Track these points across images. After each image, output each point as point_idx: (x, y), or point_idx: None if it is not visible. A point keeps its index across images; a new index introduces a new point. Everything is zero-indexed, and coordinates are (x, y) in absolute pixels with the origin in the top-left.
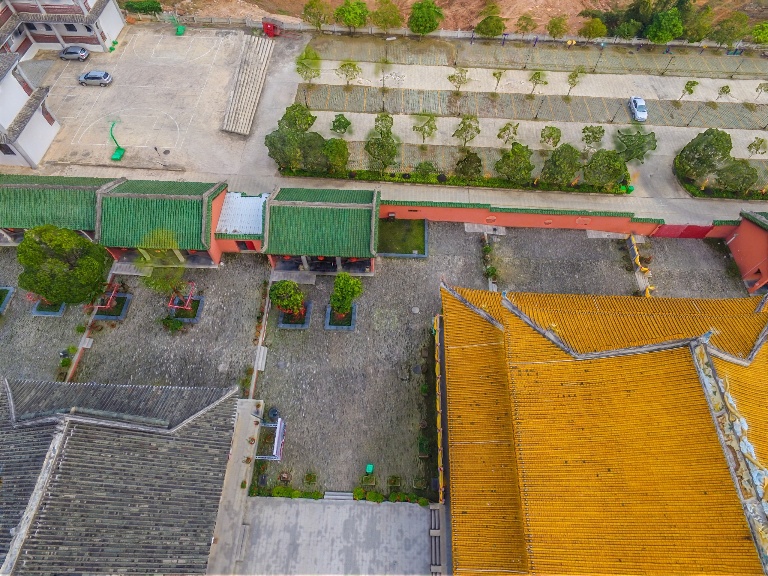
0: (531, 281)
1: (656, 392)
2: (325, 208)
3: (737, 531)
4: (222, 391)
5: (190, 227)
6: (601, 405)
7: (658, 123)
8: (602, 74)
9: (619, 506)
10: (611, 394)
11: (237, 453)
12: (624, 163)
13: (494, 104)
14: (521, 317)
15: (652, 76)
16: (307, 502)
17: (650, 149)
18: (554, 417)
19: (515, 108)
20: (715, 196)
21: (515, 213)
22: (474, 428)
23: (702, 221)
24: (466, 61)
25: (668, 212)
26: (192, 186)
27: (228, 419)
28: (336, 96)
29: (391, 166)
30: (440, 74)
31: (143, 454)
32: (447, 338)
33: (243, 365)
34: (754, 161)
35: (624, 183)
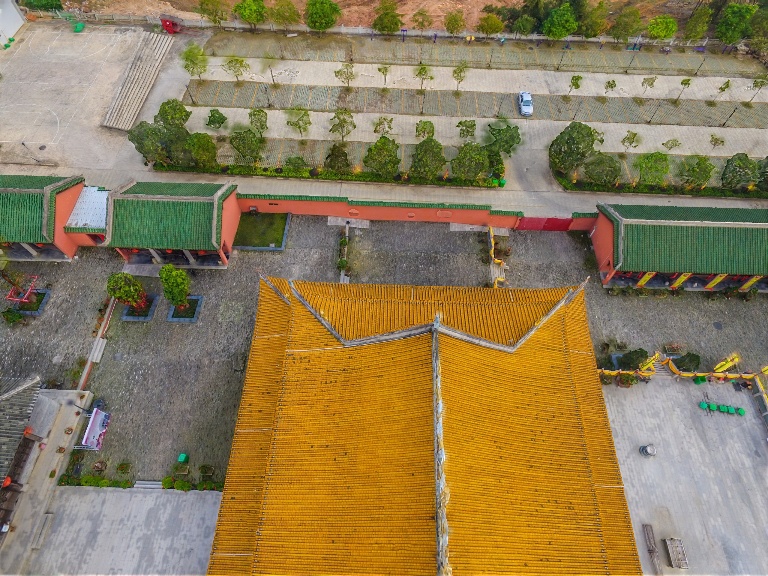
0: (385, 273)
1: (399, 377)
2: (169, 201)
3: (427, 511)
4: (24, 381)
5: (33, 220)
6: (354, 391)
7: (544, 118)
8: (497, 69)
9: (345, 489)
10: (364, 380)
11: (52, 443)
12: (500, 157)
13: (383, 99)
14: (306, 306)
15: (547, 71)
16: (115, 491)
17: (514, 142)
18: (313, 403)
19: (403, 103)
20: (586, 189)
21: (374, 206)
22: (260, 416)
23: (570, 214)
24: (363, 57)
25: (538, 205)
26: (46, 180)
27: (25, 408)
28: (226, 92)
29: (267, 161)
30: (335, 70)
31: None
32: (257, 328)
33: (78, 357)
34: (633, 155)
35: (497, 177)
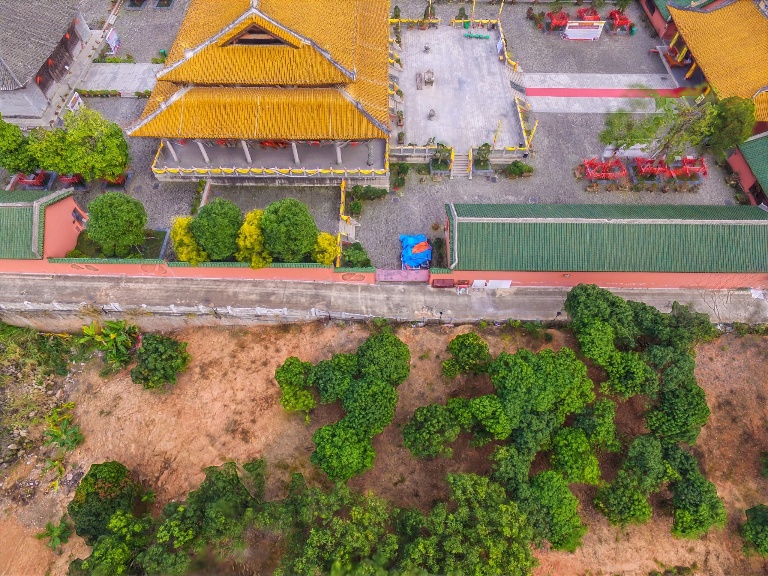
0: None
1: None
2: None
3: None
4: None
5: None
6: None
7: None
8: None
9: None
10: None
11: (89, 47)
12: None
13: None
14: None
15: None
16: (125, 64)
17: None
18: None
19: None
20: None
21: None
22: None
23: None
24: None
25: None
26: None
27: (75, 6)
28: None
29: None
30: None
31: (23, 2)
32: None
33: (100, 21)
34: None
35: None
